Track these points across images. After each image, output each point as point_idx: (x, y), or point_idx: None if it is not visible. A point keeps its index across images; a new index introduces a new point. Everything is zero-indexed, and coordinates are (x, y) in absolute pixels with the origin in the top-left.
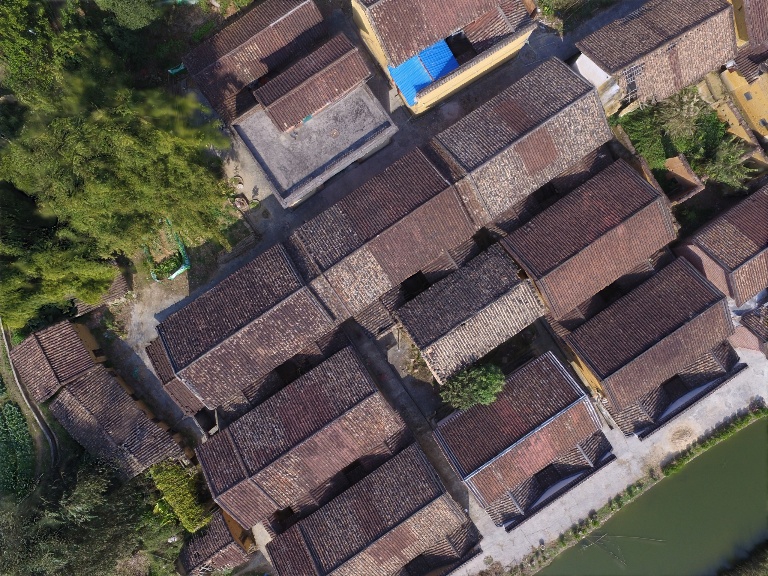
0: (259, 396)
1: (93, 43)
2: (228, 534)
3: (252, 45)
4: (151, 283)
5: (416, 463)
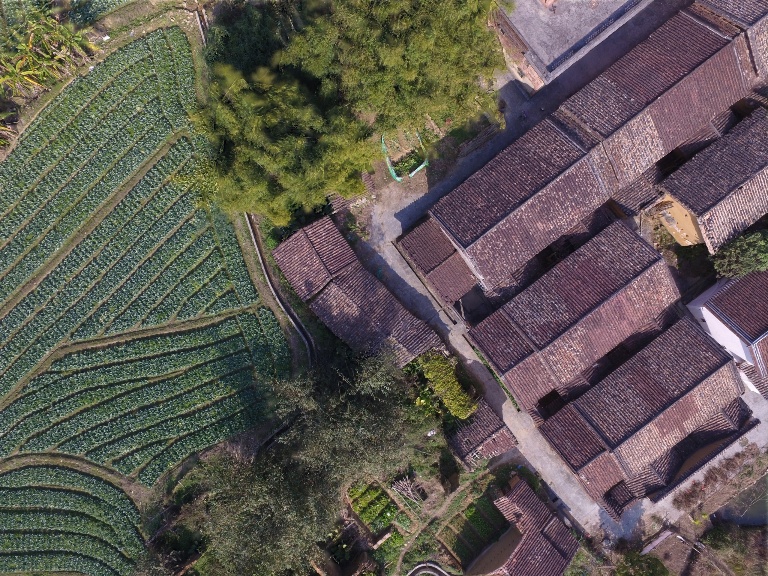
0: (525, 278)
1: None
2: (498, 419)
3: None
4: (389, 183)
5: (692, 335)
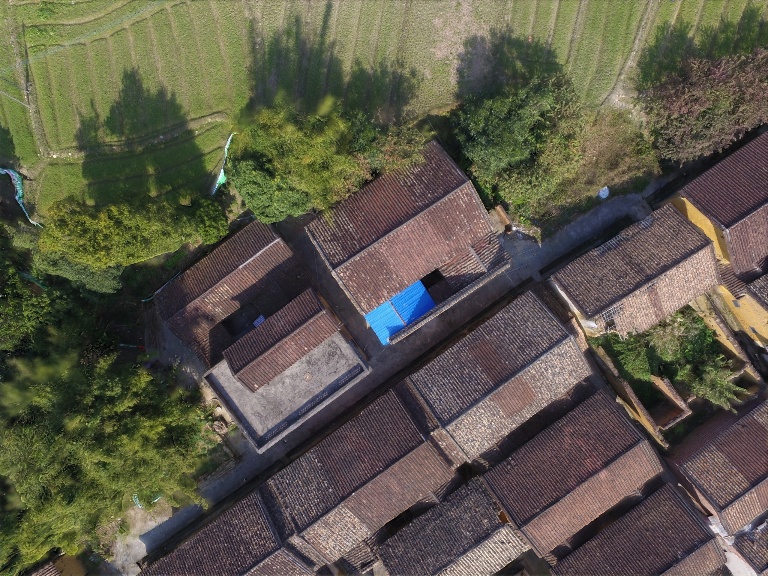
0: None
1: (62, 306)
2: None
3: (222, 286)
4: (134, 505)
5: None
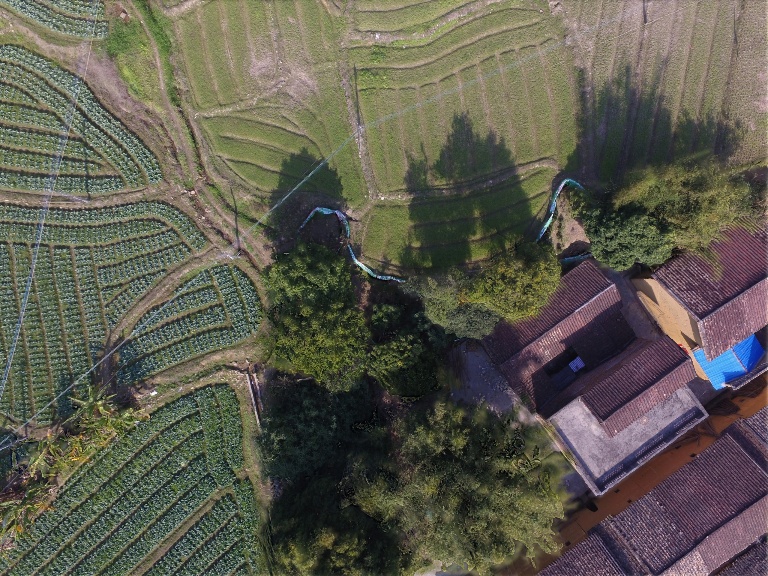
0: None
1: (419, 351)
2: None
3: (556, 330)
4: None
5: None
